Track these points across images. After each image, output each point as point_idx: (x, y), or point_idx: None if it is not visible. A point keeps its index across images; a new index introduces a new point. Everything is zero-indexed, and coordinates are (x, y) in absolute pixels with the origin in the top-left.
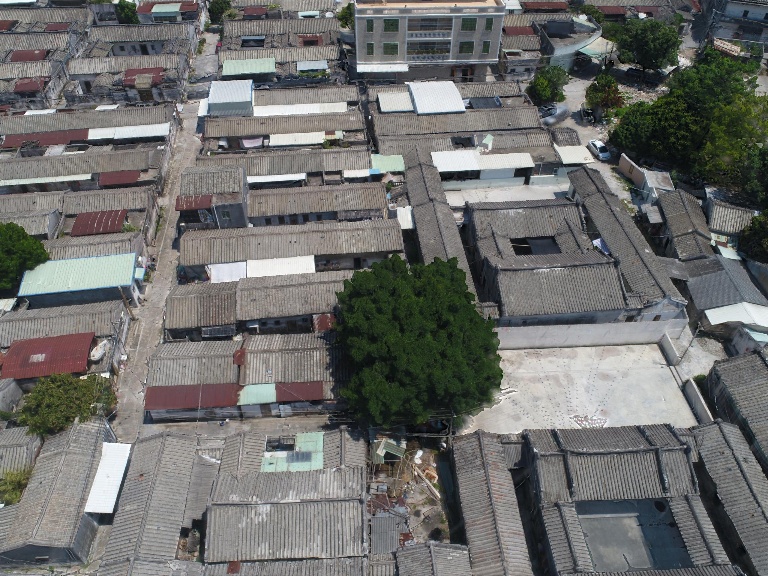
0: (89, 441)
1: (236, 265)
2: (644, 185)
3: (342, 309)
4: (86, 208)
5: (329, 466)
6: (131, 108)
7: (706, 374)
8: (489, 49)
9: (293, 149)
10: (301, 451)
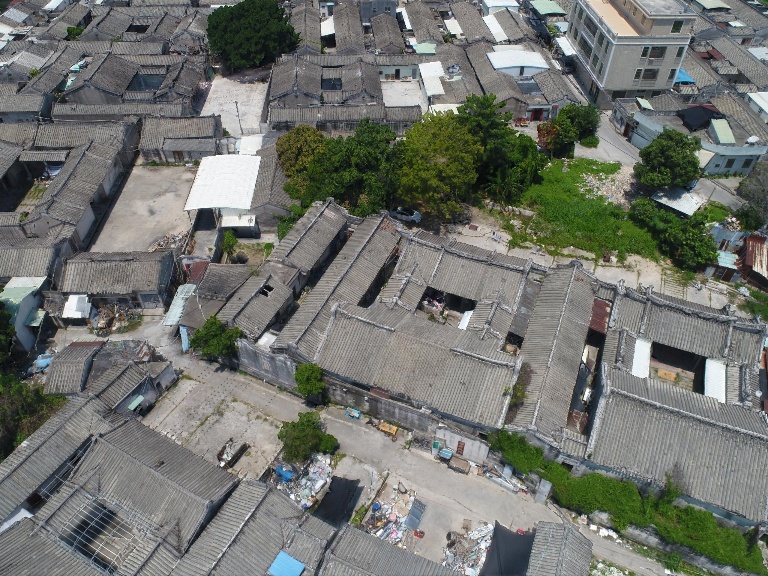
0: (236, 1)
1: None
2: None
3: None
4: None
5: None
6: None
7: None
8: (601, 72)
9: None
10: None
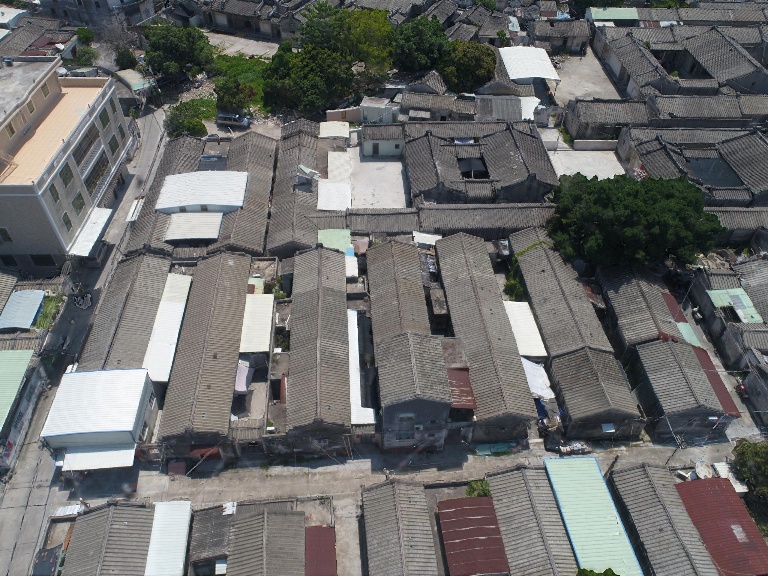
0: None
1: (524, 367)
2: (364, 116)
3: (641, 237)
4: (430, 575)
5: (737, 285)
6: (93, 575)
7: (561, 139)
8: (124, 132)
9: (274, 330)
10: (732, 301)
